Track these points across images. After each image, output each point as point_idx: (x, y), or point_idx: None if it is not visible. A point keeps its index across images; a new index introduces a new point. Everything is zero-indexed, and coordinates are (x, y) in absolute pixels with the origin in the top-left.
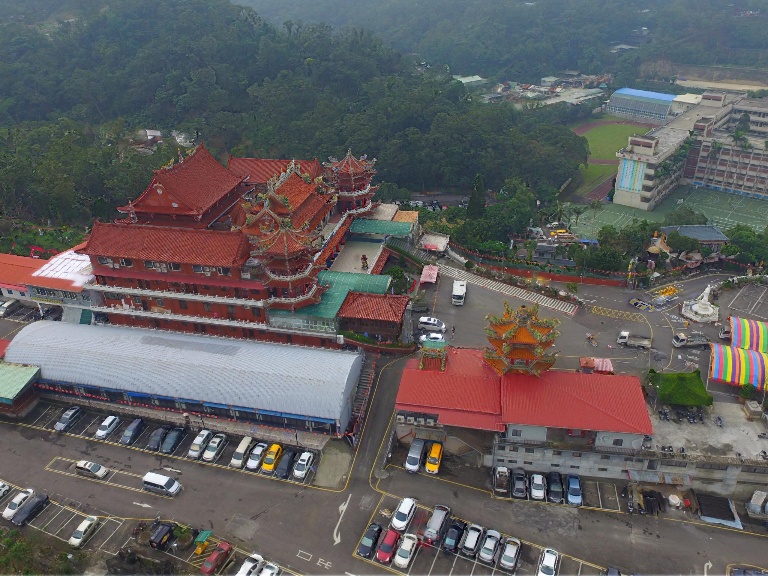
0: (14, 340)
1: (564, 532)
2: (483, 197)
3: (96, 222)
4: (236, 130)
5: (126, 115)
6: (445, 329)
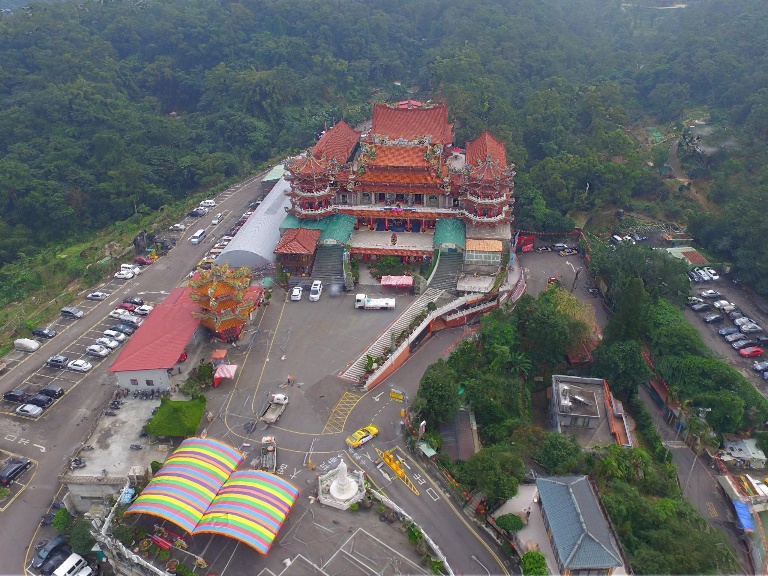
0: None
1: (104, 376)
2: (631, 311)
3: None
4: (725, 151)
5: (729, 109)
6: (314, 299)
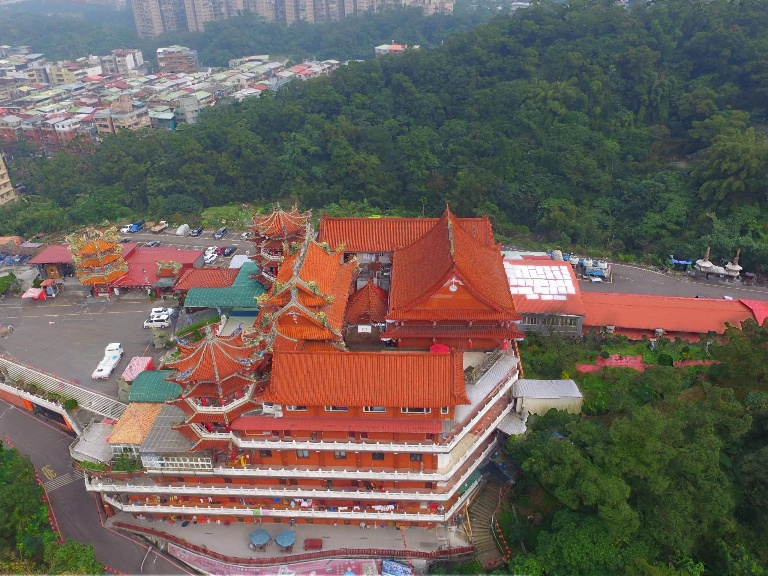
0: None
1: None
2: None
3: (486, 217)
4: None
5: None
6: None
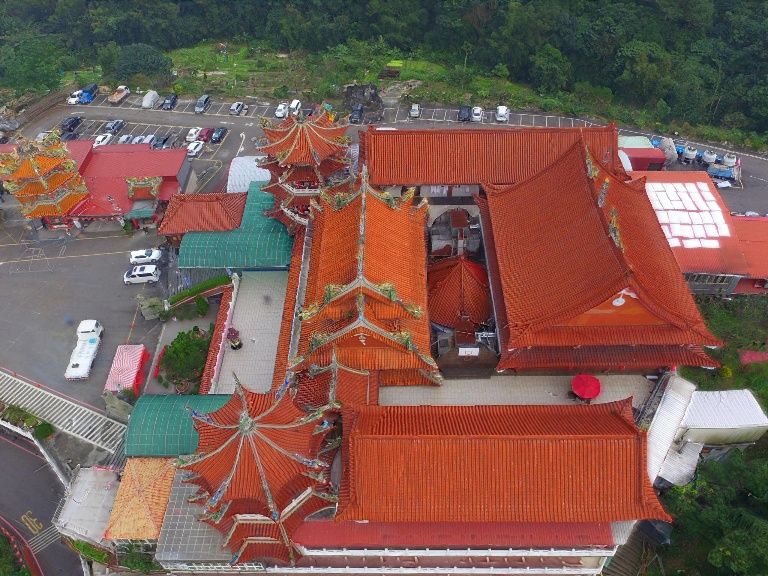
0: (622, 151)
1: None
2: None
3: (613, 125)
4: None
5: None
6: None
